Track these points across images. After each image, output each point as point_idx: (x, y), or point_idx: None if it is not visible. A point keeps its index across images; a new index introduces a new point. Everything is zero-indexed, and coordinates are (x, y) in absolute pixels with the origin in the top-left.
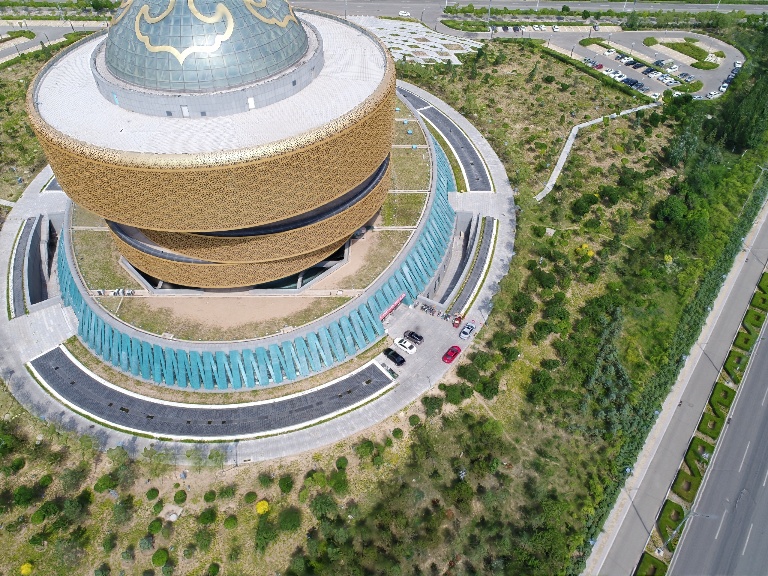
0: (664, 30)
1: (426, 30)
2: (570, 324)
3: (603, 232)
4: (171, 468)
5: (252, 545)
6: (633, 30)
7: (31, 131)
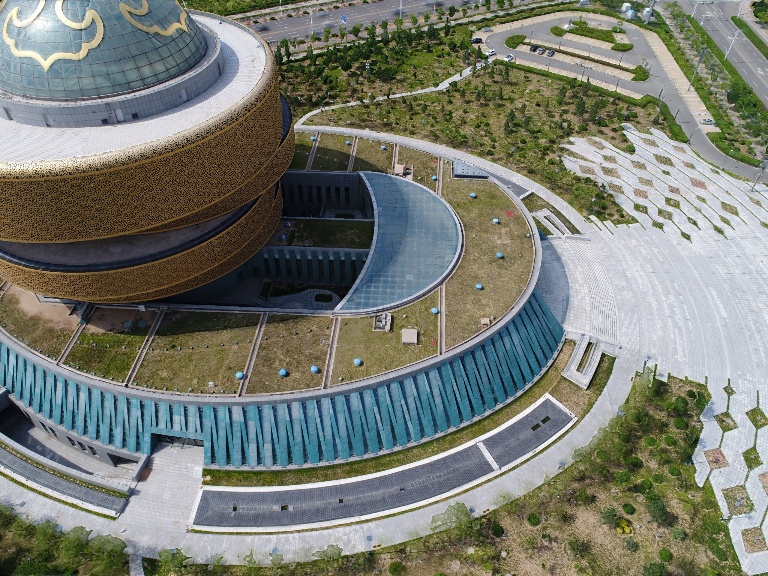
0: None
1: None
2: None
3: None
4: None
5: None
6: None
7: (409, 109)
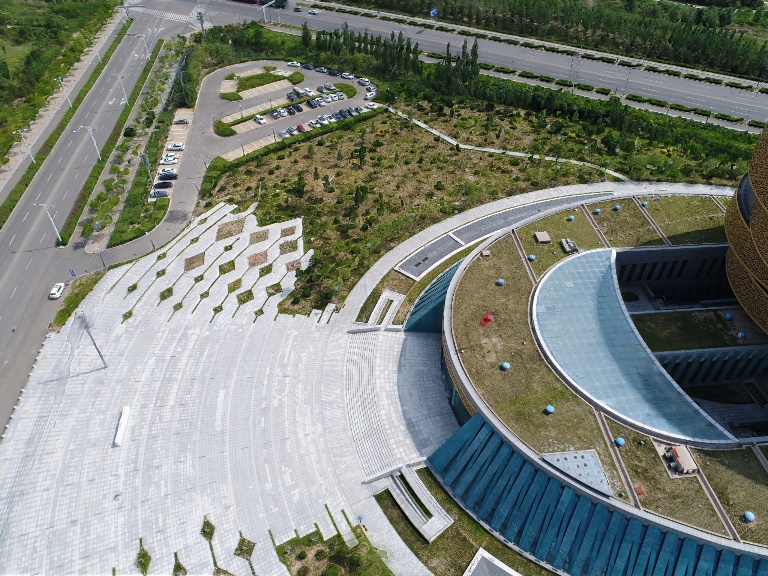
0: (199, 86)
1: (150, 260)
2: None
3: None
4: None
5: None
6: (195, 102)
7: None
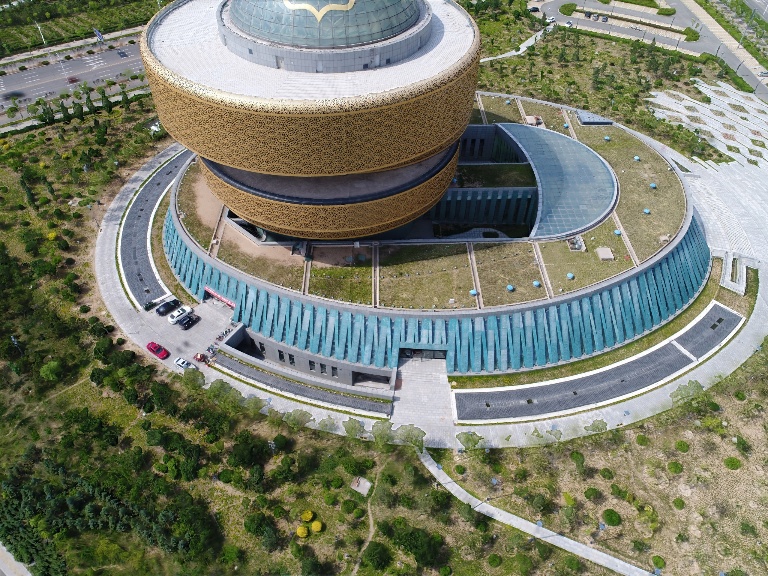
0: None
1: None
2: (172, 475)
3: (365, 575)
4: (111, 198)
5: None
6: None
7: (500, 71)
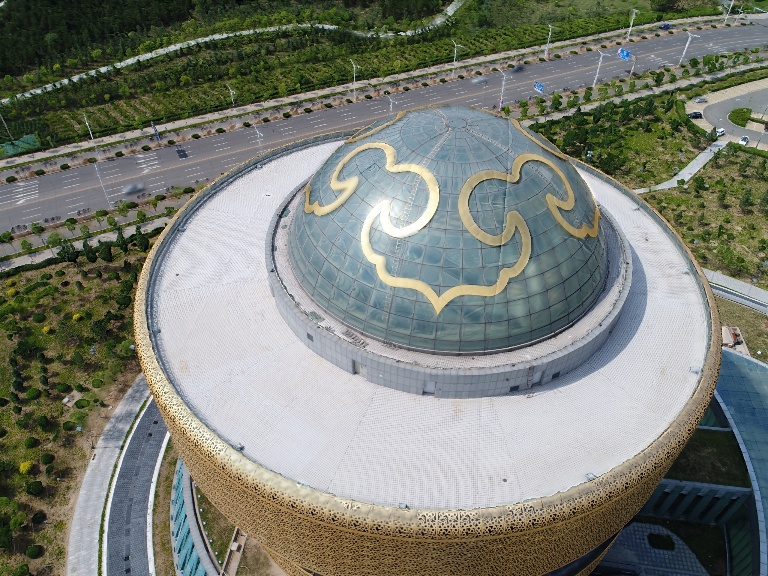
0: None
1: None
2: None
3: None
4: (120, 396)
5: (1, 461)
6: None
7: None
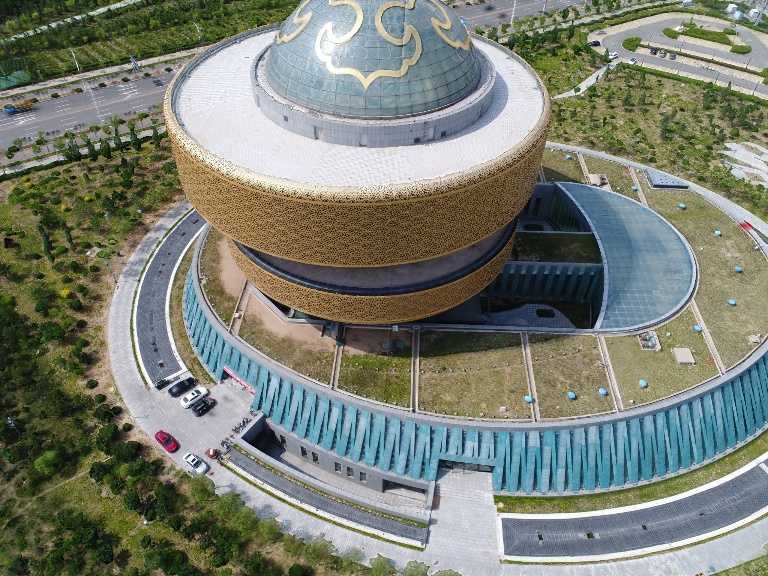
0: None
1: None
2: None
3: None
4: (132, 249)
5: None
6: None
7: (558, 115)
